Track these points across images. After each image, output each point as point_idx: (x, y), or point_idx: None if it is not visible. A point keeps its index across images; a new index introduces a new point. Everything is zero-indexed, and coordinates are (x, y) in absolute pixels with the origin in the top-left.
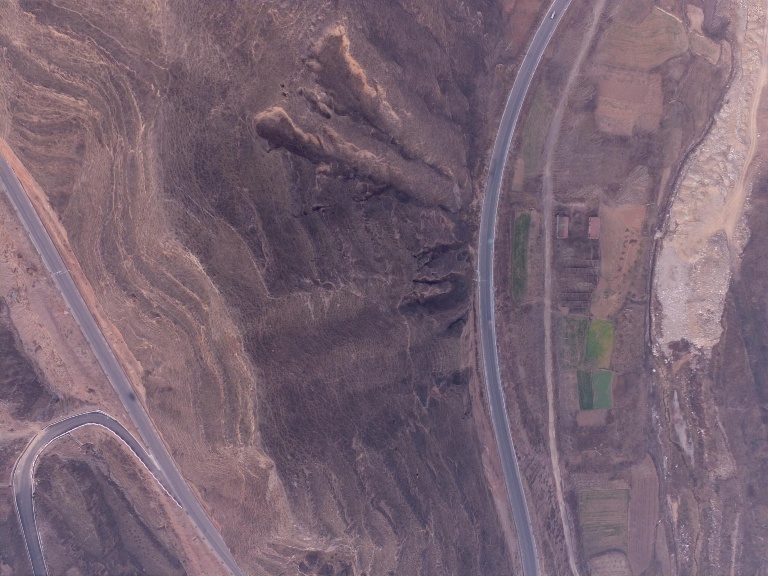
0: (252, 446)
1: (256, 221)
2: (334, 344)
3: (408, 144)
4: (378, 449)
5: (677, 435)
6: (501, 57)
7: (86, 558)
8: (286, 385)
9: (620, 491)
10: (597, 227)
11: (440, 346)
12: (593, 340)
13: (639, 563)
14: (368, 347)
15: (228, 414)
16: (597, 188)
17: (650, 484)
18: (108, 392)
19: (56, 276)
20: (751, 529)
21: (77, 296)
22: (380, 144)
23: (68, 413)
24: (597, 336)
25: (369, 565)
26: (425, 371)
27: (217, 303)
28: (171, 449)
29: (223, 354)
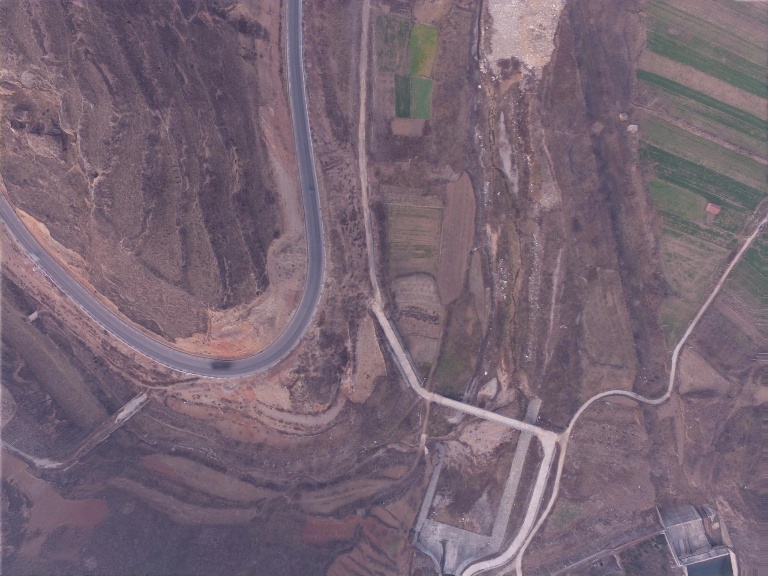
0: None
1: None
2: None
3: None
4: (104, 9)
5: (501, 160)
6: None
7: None
8: None
9: (434, 210)
10: None
11: None
12: (415, 45)
13: (449, 290)
14: None
15: None
16: None
17: (466, 205)
18: None
19: None
20: (574, 268)
21: None
22: None
23: None
24: (419, 41)
25: (78, 121)
26: None
27: None
28: None
29: None
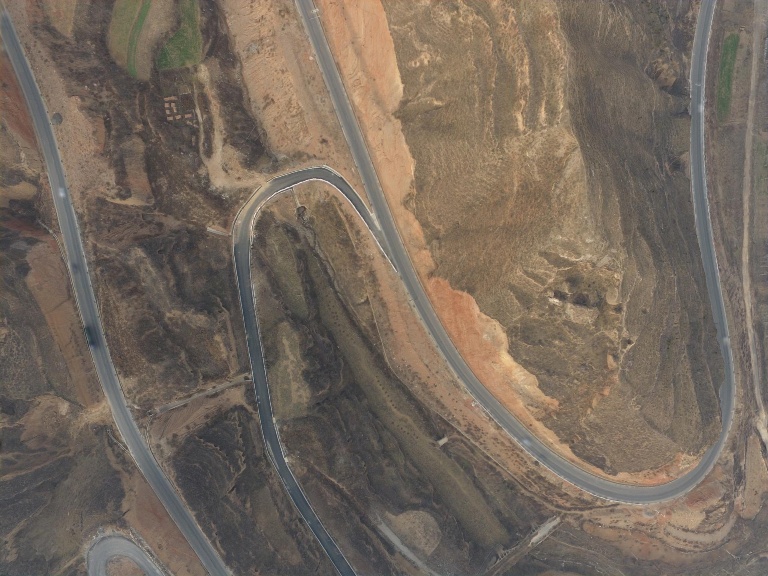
0: (559, 124)
1: None
2: (612, 68)
3: None
4: None
5: None
6: None
7: (293, 318)
8: (587, 77)
9: None
10: None
11: (673, 125)
12: None
13: None
14: (632, 87)
15: (532, 97)
16: None
17: None
18: (341, 143)
19: (306, 21)
20: None
21: (324, 43)
22: None
23: (295, 167)
24: None
25: (628, 295)
26: None
27: None
28: (416, 186)
29: (531, 38)
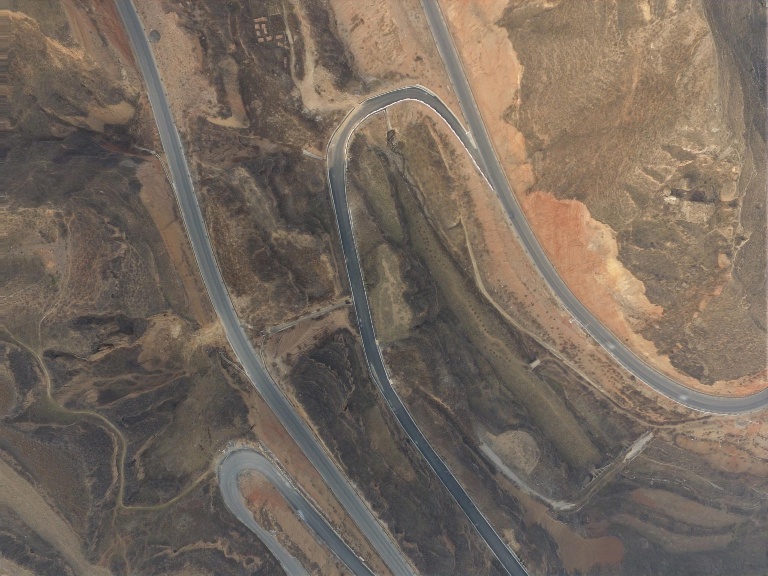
0: (691, 8)
1: None
2: None
3: None
4: None
5: None
6: None
7: (390, 241)
8: None
9: None
10: None
11: (762, 33)
12: None
13: None
14: None
15: None
16: None
17: None
18: (436, 61)
19: None
20: None
21: None
22: None
23: (387, 87)
24: None
25: (745, 189)
26: None
27: None
28: (522, 95)
29: None
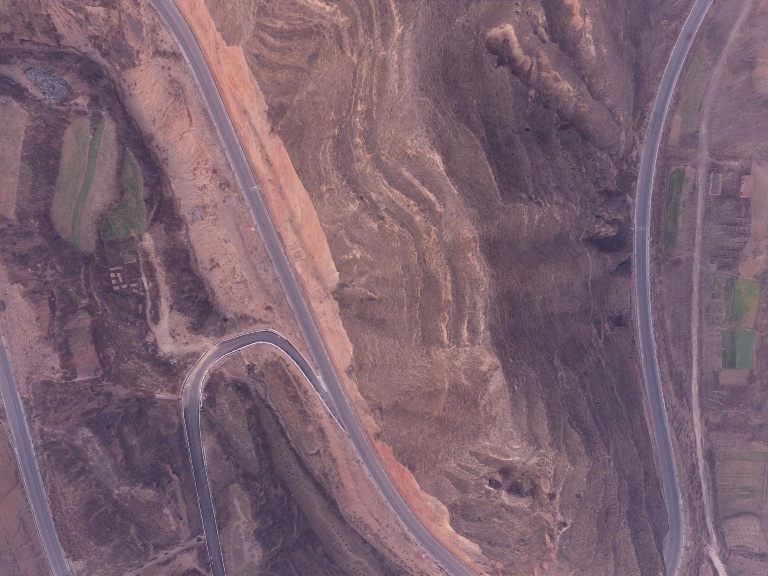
0: (481, 345)
1: (483, 132)
2: (540, 262)
3: (595, 83)
4: (573, 370)
5: None
6: (665, 14)
7: (245, 476)
8: (509, 291)
9: (758, 453)
10: (751, 185)
11: (612, 284)
12: (739, 299)
13: None
14: (563, 271)
15: (454, 314)
16: (762, 143)
17: None
18: (285, 310)
19: (247, 193)
20: None
21: (265, 214)
22: (577, 77)
23: (241, 330)
24: (743, 295)
25: (561, 484)
26: (599, 307)
27: (454, 204)
28: (356, 364)
29: (453, 256)
